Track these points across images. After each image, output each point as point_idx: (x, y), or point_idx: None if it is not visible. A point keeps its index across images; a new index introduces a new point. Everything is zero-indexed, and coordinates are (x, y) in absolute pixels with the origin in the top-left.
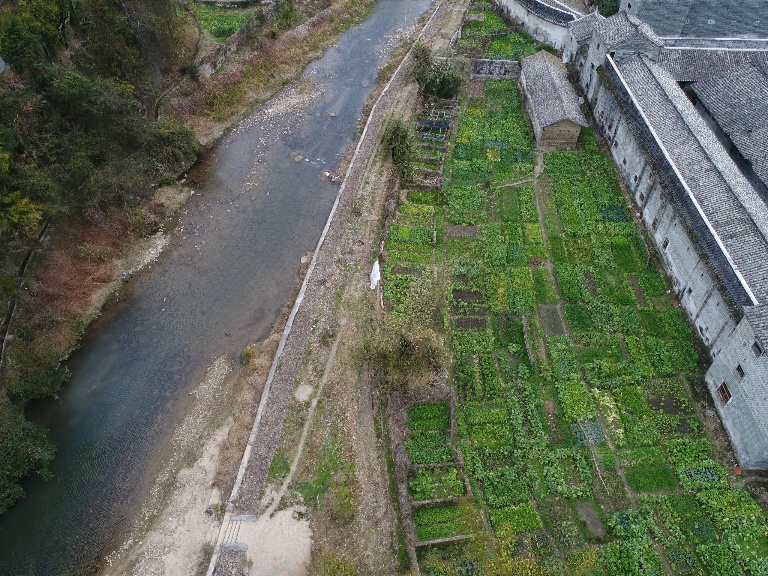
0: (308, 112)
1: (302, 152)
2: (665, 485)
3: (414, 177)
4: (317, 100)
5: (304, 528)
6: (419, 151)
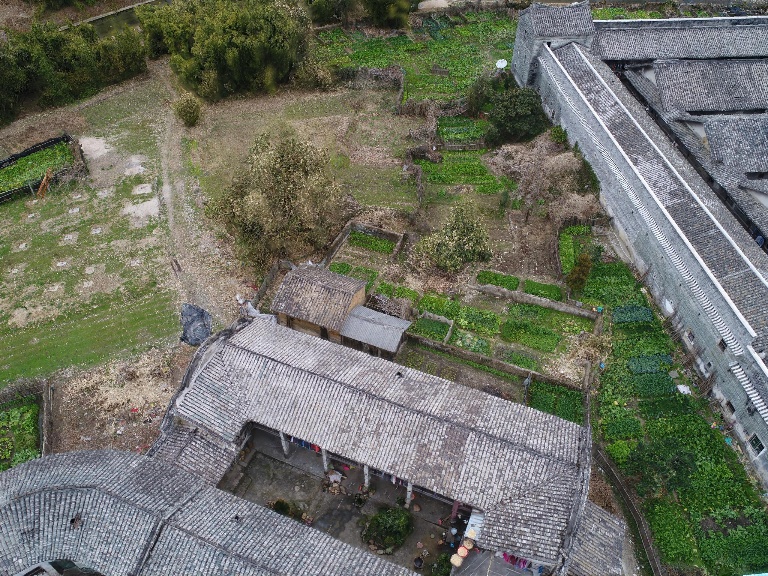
0: (731, 0)
1: (682, 2)
2: (494, 57)
3: (668, 8)
4: (750, 2)
5: (446, 6)
6: (704, 13)
